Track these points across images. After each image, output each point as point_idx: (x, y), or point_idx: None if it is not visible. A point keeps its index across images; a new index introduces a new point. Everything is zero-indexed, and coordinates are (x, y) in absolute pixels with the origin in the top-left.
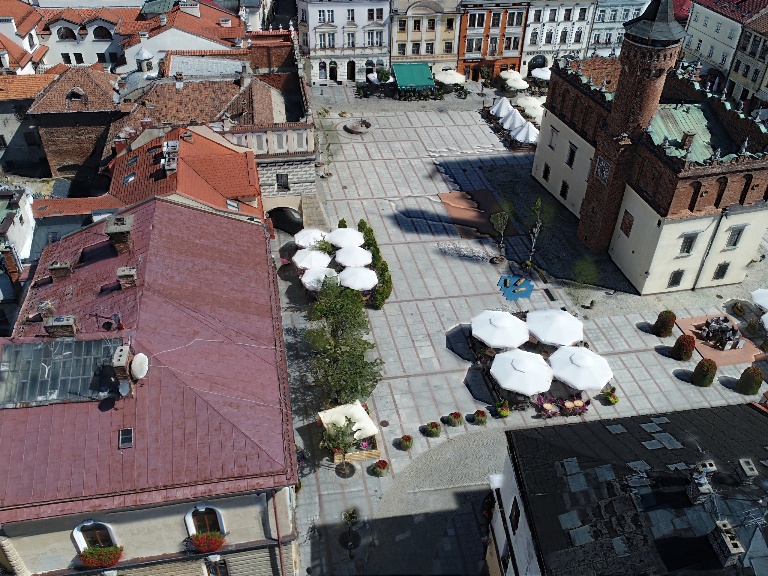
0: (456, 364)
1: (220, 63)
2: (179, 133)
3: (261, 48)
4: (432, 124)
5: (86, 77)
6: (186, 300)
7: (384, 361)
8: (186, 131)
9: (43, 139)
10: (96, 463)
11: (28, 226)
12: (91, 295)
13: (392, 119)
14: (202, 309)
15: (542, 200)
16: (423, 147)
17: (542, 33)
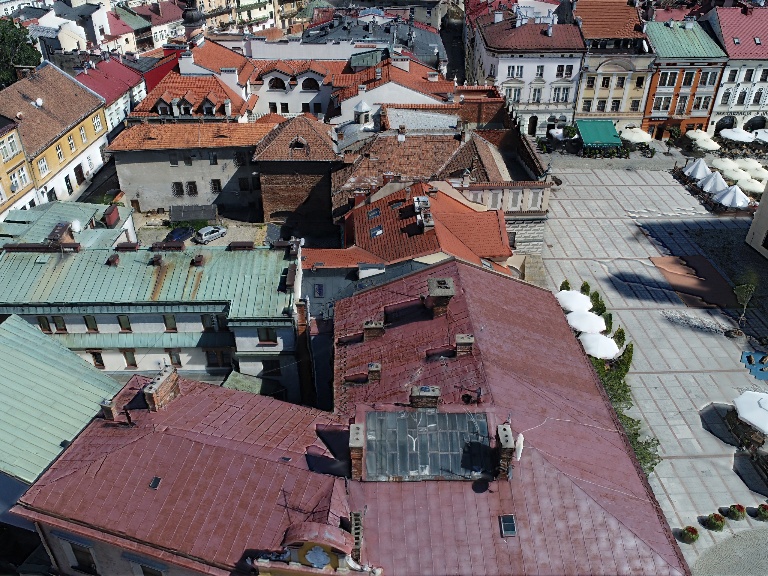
0: (719, 448)
1: (432, 117)
2: (423, 188)
3: (473, 103)
4: (623, 183)
5: (308, 127)
6: (521, 372)
7: (639, 438)
8: (427, 186)
9: (262, 185)
10: (481, 551)
11: (300, 277)
12: (416, 359)
13: (581, 176)
14: (538, 383)
15: (764, 270)
16: (620, 207)
17: (735, 93)
